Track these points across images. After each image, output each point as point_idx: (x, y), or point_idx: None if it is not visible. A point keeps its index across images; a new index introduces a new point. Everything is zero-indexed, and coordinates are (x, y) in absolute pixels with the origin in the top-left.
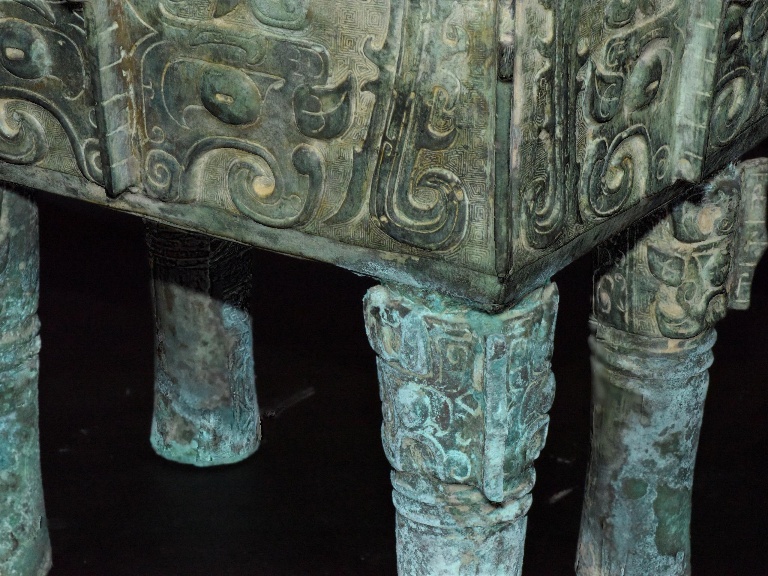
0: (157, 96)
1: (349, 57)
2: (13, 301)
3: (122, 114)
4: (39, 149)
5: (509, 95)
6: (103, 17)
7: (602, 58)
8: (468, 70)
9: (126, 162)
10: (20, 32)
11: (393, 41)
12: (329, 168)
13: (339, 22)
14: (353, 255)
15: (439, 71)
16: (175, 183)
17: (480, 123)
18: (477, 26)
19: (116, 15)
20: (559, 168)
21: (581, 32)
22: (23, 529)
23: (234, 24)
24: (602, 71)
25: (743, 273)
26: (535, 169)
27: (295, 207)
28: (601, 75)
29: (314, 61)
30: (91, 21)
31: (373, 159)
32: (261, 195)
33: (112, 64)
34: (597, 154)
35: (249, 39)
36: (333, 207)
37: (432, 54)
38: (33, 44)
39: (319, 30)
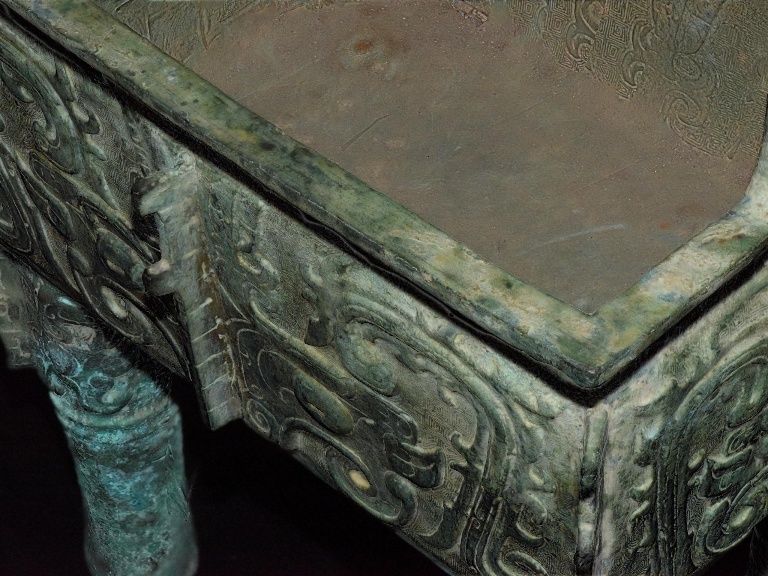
0: (254, 366)
1: (438, 437)
2: (145, 385)
3: (219, 368)
4: (146, 340)
5: (590, 564)
6: (194, 298)
7: (723, 450)
8: (555, 506)
9: (226, 403)
10: (120, 253)
11: (480, 449)
12: (421, 502)
13: (427, 408)
14: (448, 567)
15: (525, 495)
16: (275, 435)
17: (567, 546)
18: (564, 479)
19: (209, 292)
20: (663, 557)
21: (694, 449)
22: (163, 553)
23: (324, 356)
24: (723, 459)
25: None
26: (631, 574)
27: (390, 511)
28: (720, 465)
29: (402, 425)
30: (180, 304)
31: (463, 519)
32: (357, 484)
33: (206, 332)
34: (715, 518)
35: (338, 378)
36: (426, 529)
37: (518, 480)
38: (133, 268)
39: (407, 403)
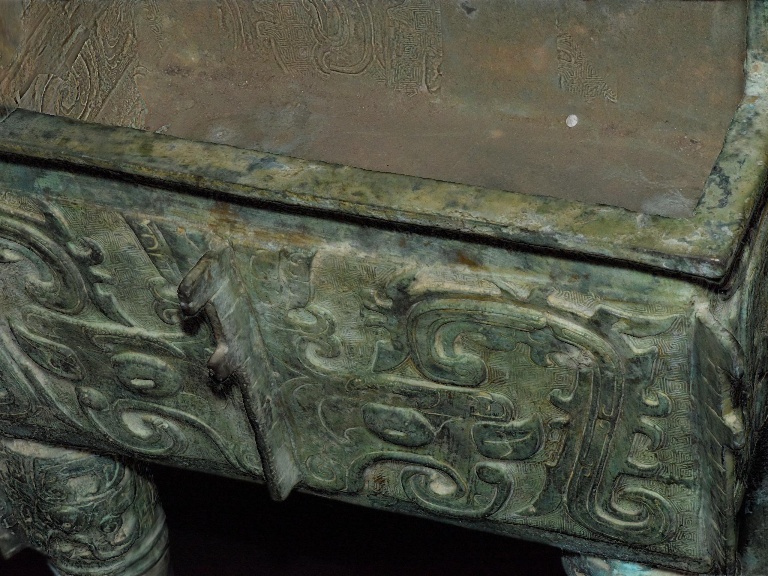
0: None
1: None
2: None
3: None
4: None
5: None
6: None
7: None
8: None
9: None
10: None
11: None
12: None
13: None
14: None
15: None
16: None
17: None
18: None
19: None
20: None
21: None
22: None
23: None
24: None
25: (1, 516)
26: None
27: None
28: None
29: None
30: None
31: None
32: None
33: None
34: None
35: None
36: None
37: None
38: None
39: None
